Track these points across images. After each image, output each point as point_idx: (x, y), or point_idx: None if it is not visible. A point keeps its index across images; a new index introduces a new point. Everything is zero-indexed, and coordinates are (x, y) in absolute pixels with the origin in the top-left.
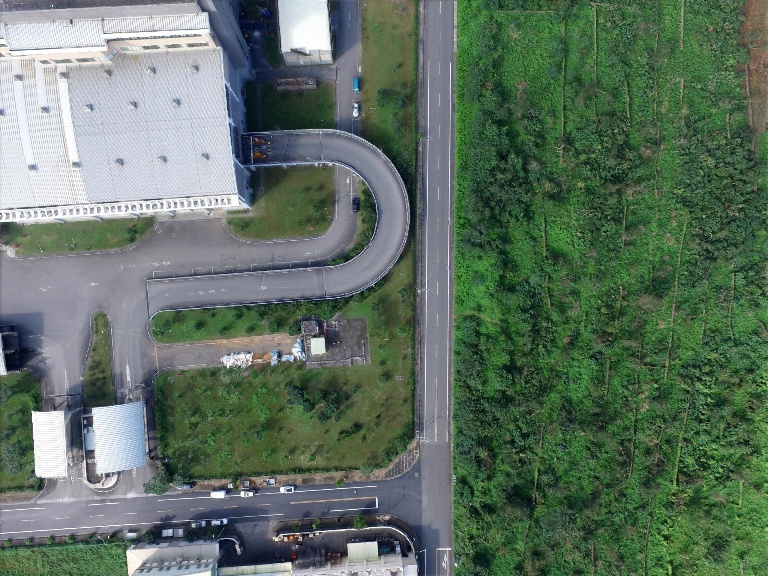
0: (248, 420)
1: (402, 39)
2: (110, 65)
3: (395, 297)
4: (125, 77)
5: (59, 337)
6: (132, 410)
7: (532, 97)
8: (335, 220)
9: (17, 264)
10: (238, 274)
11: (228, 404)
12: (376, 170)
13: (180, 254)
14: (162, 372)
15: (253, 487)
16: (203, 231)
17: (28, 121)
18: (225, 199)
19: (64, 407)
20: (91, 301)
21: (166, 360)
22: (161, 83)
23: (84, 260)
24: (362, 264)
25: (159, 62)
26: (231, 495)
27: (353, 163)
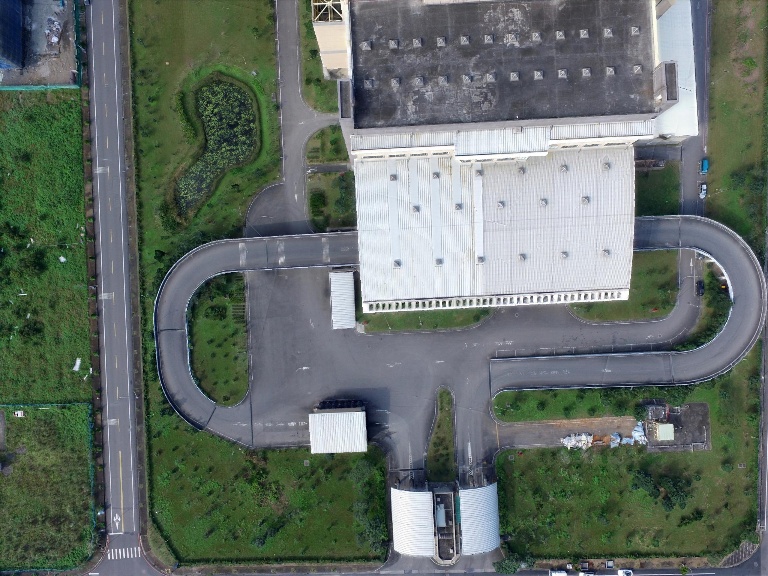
0: (588, 502)
1: (750, 119)
2: (523, 163)
3: (737, 383)
4: (537, 174)
5: (404, 412)
6: (491, 492)
7: None
8: (677, 303)
9: (366, 340)
10: (582, 356)
11: (569, 485)
12: (733, 256)
13: (523, 334)
14: (503, 450)
15: (591, 568)
16: (545, 311)
17: (441, 217)
18: (616, 293)
19: (408, 481)
20: (436, 378)
21: (507, 439)
22: (572, 181)
23: (430, 338)
24: (712, 350)
25: (571, 160)
26: (568, 575)
27: (710, 249)
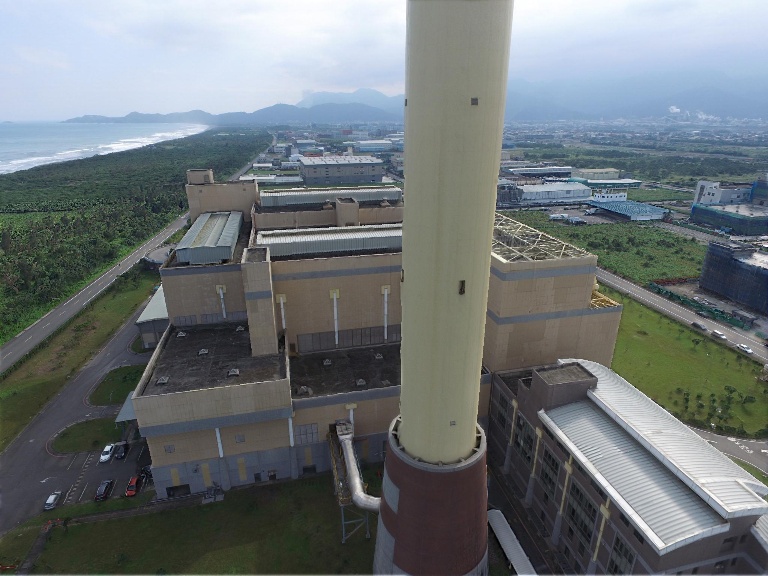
0: None
1: None
2: None
3: None
4: None
5: None
6: None
7: (3, 296)
8: None
9: None
10: None
11: None
12: None
13: None
14: None
15: None
16: None
17: None
18: None
19: None
20: None
21: None
22: None
23: None
24: None
25: None
26: None
27: None
